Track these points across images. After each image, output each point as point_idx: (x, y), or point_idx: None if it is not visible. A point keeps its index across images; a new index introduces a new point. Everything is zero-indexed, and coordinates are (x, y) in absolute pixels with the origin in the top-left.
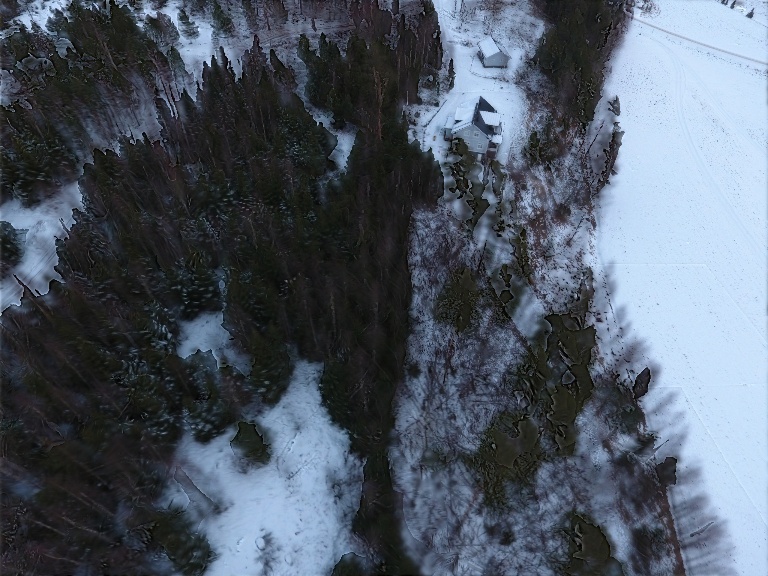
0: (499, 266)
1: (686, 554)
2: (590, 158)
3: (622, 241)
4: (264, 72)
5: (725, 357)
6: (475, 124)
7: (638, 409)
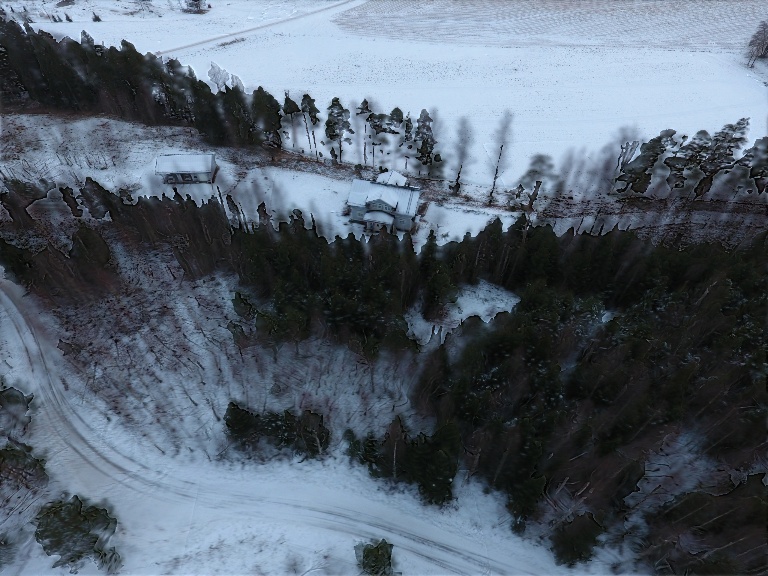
0: (563, 229)
1: (725, 200)
2: (351, 164)
3: (470, 172)
4: (444, 351)
5: (570, 158)
6: (419, 189)
7: (641, 197)
